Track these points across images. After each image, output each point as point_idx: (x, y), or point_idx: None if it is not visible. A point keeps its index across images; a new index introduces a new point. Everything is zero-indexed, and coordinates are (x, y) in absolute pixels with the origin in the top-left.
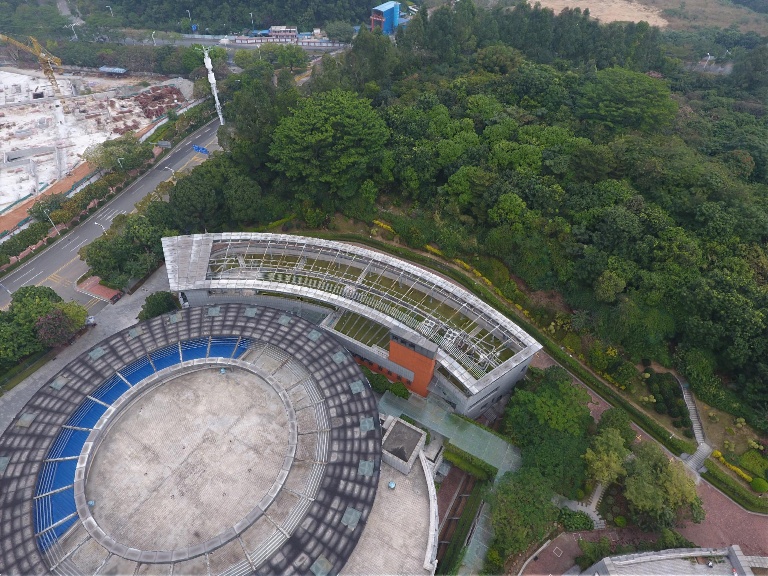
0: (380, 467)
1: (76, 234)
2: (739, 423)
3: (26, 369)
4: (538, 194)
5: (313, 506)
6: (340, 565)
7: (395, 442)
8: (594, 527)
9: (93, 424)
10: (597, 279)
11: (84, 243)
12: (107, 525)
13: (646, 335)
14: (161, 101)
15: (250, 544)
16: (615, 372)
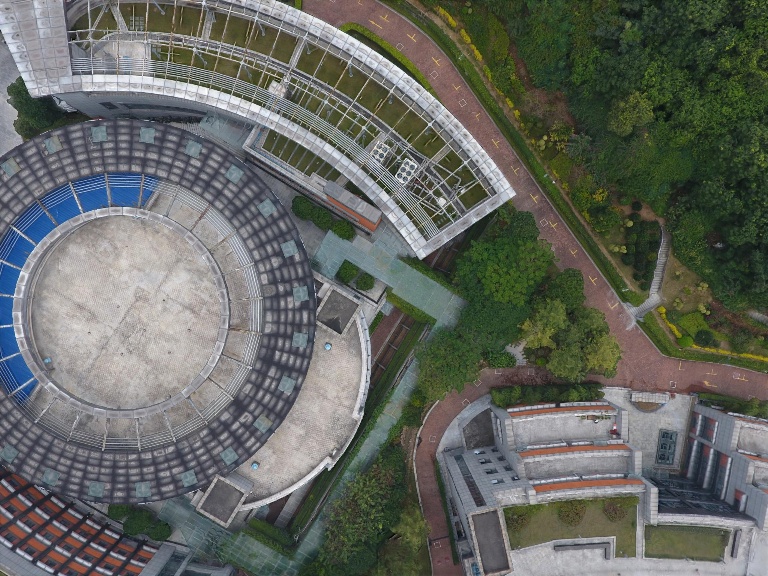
0: (314, 339)
1: None
2: (701, 287)
3: None
4: None
5: (251, 374)
6: (279, 422)
7: (330, 312)
8: (516, 365)
9: (15, 280)
10: (619, 98)
11: None
12: (71, 378)
13: (648, 185)
14: None
15: (202, 395)
16: (595, 217)
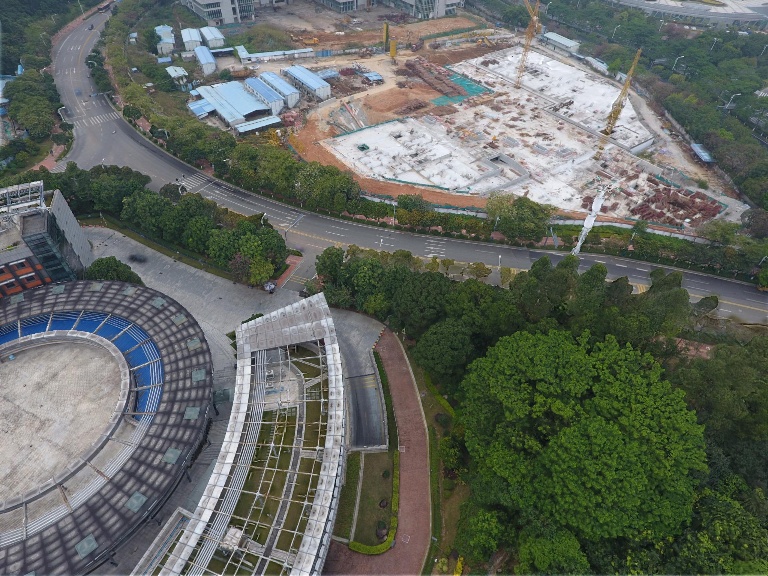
0: None
1: (399, 236)
2: None
3: (225, 271)
4: None
5: None
6: None
7: None
8: None
9: None
10: None
11: (387, 246)
12: None
13: None
14: (674, 209)
15: None
16: None
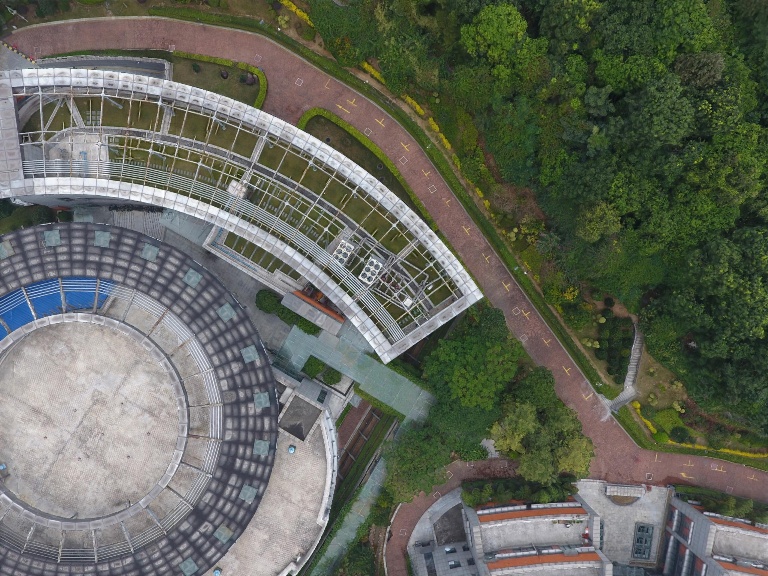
0: (276, 446)
1: None
2: (675, 385)
3: None
4: (552, 6)
5: (211, 483)
6: (240, 531)
7: (292, 418)
8: (488, 457)
9: None
10: (587, 205)
11: None
12: (26, 484)
13: (619, 289)
14: None
15: (162, 500)
16: (566, 312)
